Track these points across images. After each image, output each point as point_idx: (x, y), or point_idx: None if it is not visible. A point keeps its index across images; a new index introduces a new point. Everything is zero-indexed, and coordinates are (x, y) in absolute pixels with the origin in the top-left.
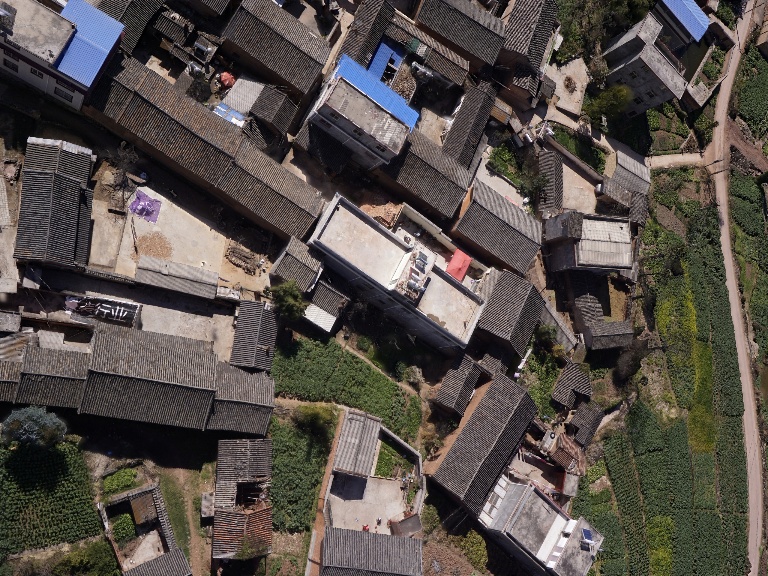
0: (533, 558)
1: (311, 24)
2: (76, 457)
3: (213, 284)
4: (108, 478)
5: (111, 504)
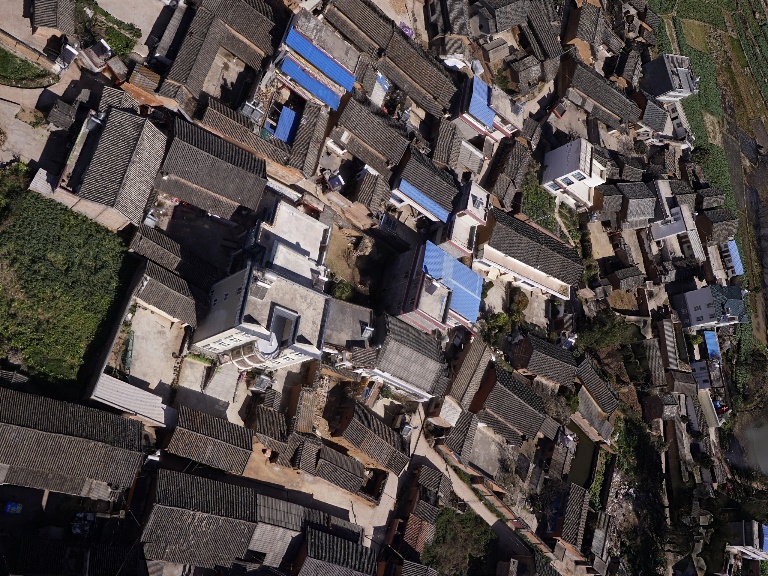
0: None
1: None
2: None
3: None
4: None
5: None
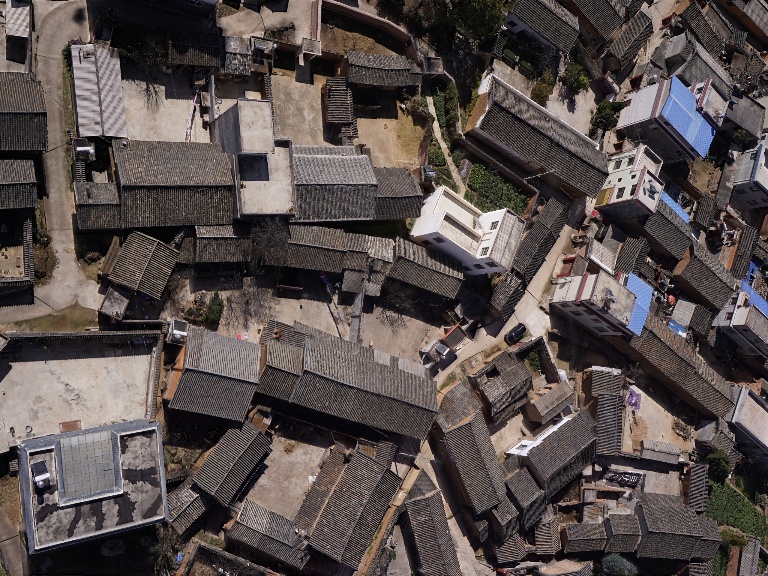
0: None
1: (703, 245)
2: None
3: (678, 454)
4: None
5: None
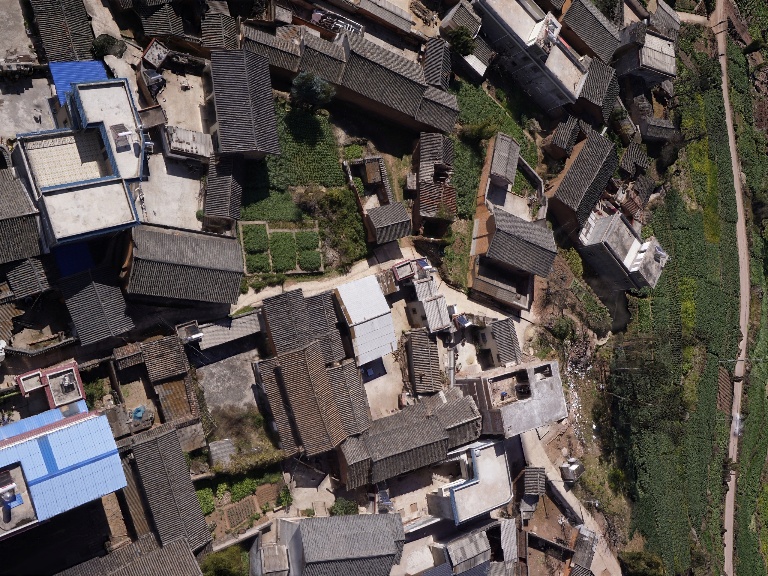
0: (621, 265)
1: None
2: (327, 127)
3: (410, 21)
4: (346, 148)
5: (353, 164)
